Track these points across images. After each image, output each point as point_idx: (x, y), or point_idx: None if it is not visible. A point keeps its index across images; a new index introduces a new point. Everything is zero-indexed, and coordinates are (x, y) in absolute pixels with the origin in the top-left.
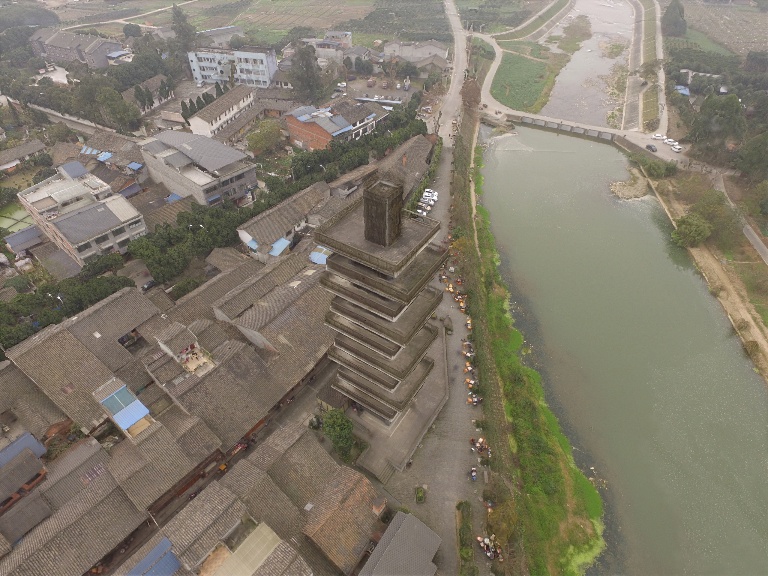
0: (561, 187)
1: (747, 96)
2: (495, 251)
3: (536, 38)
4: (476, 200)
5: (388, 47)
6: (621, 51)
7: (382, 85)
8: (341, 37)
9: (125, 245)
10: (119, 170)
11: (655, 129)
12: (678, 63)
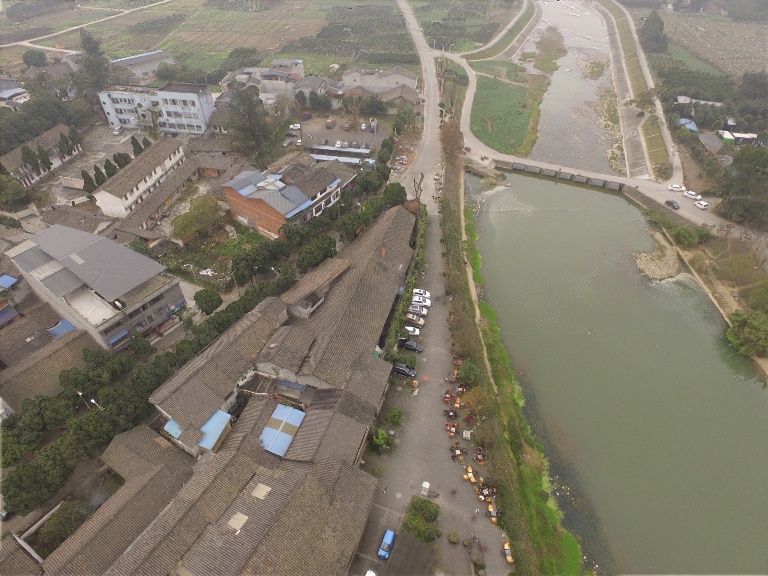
0: (577, 266)
1: (764, 133)
2: (514, 380)
3: (509, 56)
4: (477, 293)
5: (347, 76)
6: (602, 70)
7: (343, 125)
8: (291, 66)
9: None
10: None
11: (669, 177)
12: (674, 89)
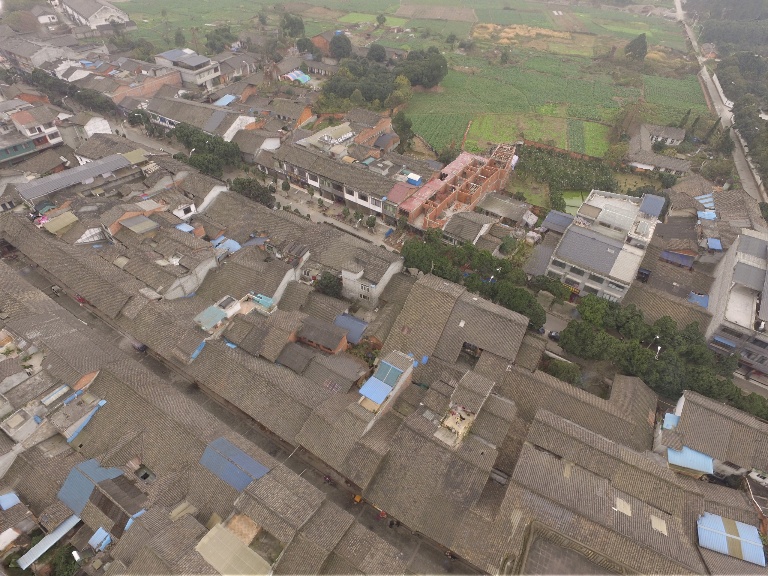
0: None
1: None
2: None
3: None
4: None
5: None
6: None
7: None
8: None
9: (590, 292)
10: (699, 235)
11: None
12: None
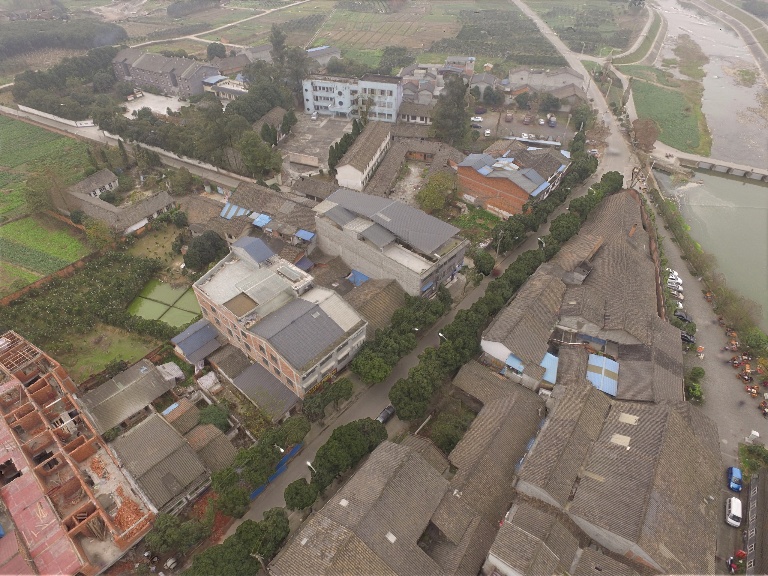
0: None
1: None
2: None
3: (651, 62)
4: None
5: (515, 74)
6: (754, 78)
7: (520, 119)
8: (466, 63)
9: (343, 360)
10: (282, 238)
11: None
12: None
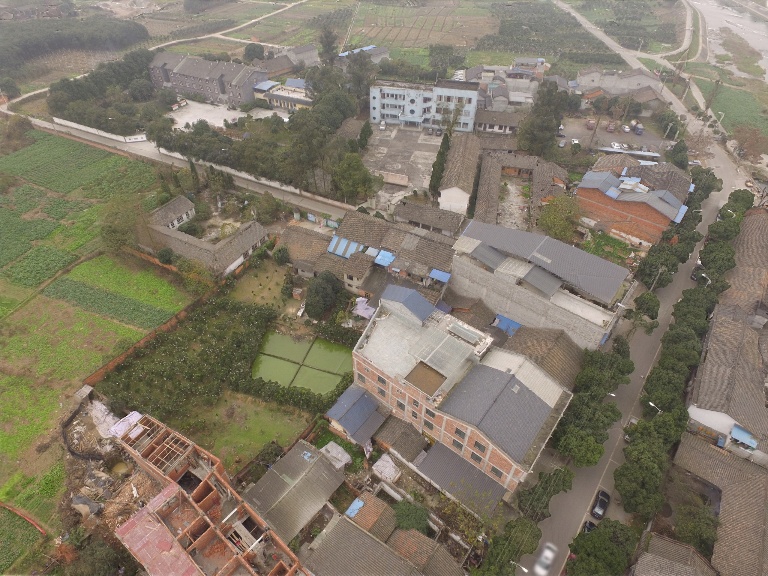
0: None
1: None
2: None
3: (705, 58)
4: None
5: (586, 76)
6: None
7: (602, 126)
8: (537, 65)
9: None
10: (411, 279)
11: None
12: None
